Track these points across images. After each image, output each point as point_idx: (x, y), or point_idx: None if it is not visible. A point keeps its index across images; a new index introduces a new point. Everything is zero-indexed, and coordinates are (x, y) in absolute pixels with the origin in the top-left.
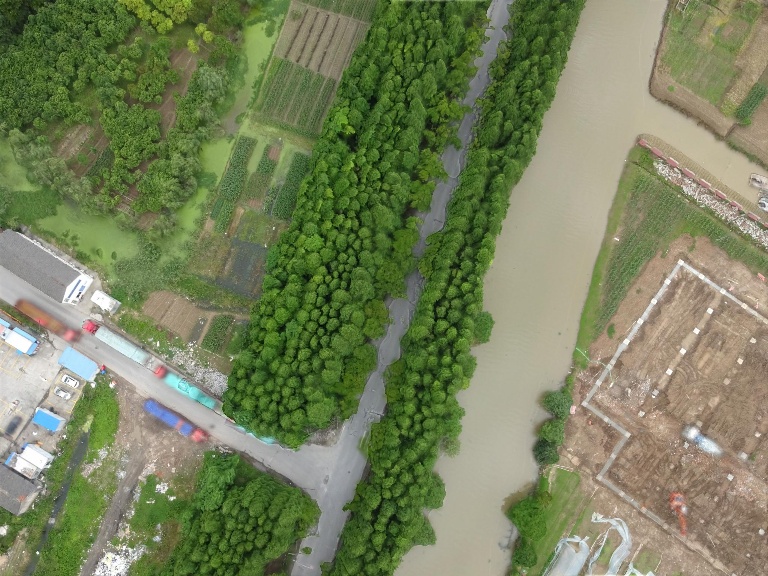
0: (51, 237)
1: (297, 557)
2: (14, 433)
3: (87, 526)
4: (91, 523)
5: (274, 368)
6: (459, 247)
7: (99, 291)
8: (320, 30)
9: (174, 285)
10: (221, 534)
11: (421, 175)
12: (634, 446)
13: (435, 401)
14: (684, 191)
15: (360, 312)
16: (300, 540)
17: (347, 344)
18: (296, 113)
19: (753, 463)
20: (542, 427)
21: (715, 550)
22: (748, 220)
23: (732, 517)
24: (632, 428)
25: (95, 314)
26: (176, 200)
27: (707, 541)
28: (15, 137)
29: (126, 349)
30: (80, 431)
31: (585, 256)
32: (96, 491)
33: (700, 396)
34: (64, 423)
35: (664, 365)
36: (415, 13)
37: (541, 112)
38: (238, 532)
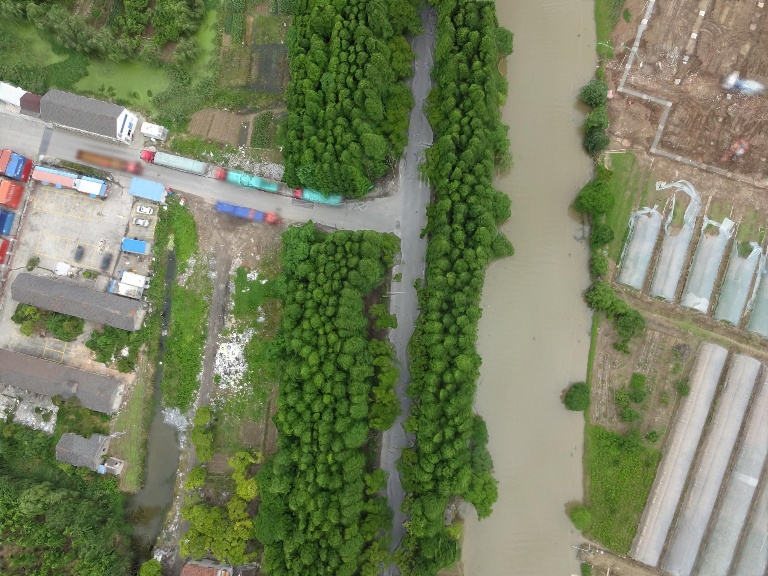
0: (90, 95)
1: (391, 298)
2: (109, 269)
3: (197, 326)
4: (199, 323)
5: (320, 116)
6: None
7: (146, 122)
8: None
9: (210, 101)
10: (316, 273)
11: None
12: (678, 111)
13: (476, 99)
14: None
15: (384, 45)
16: (389, 283)
17: (380, 75)
18: None
19: None
20: (585, 118)
21: None
22: None
23: None
24: (672, 97)
25: (148, 147)
26: (190, 23)
27: None
28: (32, 9)
29: (185, 164)
30: (166, 251)
31: None
32: (195, 295)
33: (730, 47)
34: (150, 247)
35: (687, 30)
36: None
37: None
38: (330, 262)
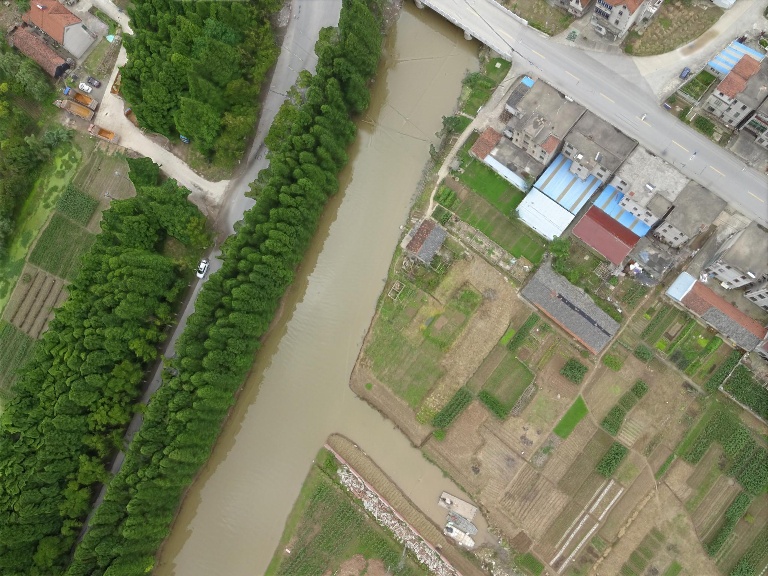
0: None
1: None
2: None
3: None
4: None
5: None
6: (83, 573)
7: None
8: (45, 295)
9: None
10: None
11: (69, 486)
12: None
13: None
14: (364, 506)
15: None
16: None
17: None
18: (11, 380)
19: None
20: None
21: None
22: (427, 548)
23: None
24: None
25: None
26: None
27: None
28: None
29: None
30: None
31: (258, 562)
32: None
33: None
34: None
35: None
36: (74, 323)
37: (192, 429)
38: None
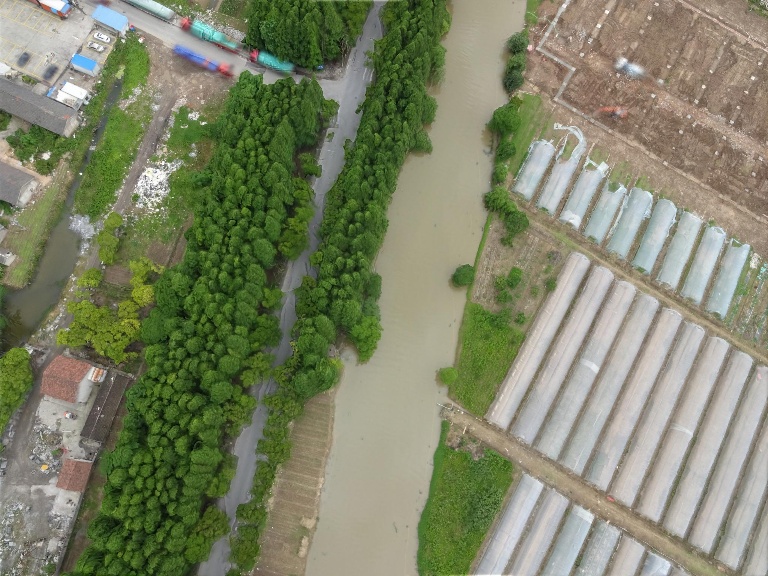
0: None
1: (318, 162)
2: (51, 80)
3: (127, 147)
4: (131, 145)
5: None
6: None
7: None
8: None
9: None
10: None
11: None
12: (579, 75)
13: (426, 6)
14: None
15: None
16: None
17: None
18: None
19: (668, 85)
20: None
21: (649, 145)
22: None
23: (658, 122)
24: (576, 65)
25: None
26: None
27: (642, 138)
28: None
29: (153, 6)
30: (113, 78)
31: None
32: (133, 120)
33: (624, 40)
34: (98, 70)
35: (594, 20)
36: None
37: None
38: (275, 98)
